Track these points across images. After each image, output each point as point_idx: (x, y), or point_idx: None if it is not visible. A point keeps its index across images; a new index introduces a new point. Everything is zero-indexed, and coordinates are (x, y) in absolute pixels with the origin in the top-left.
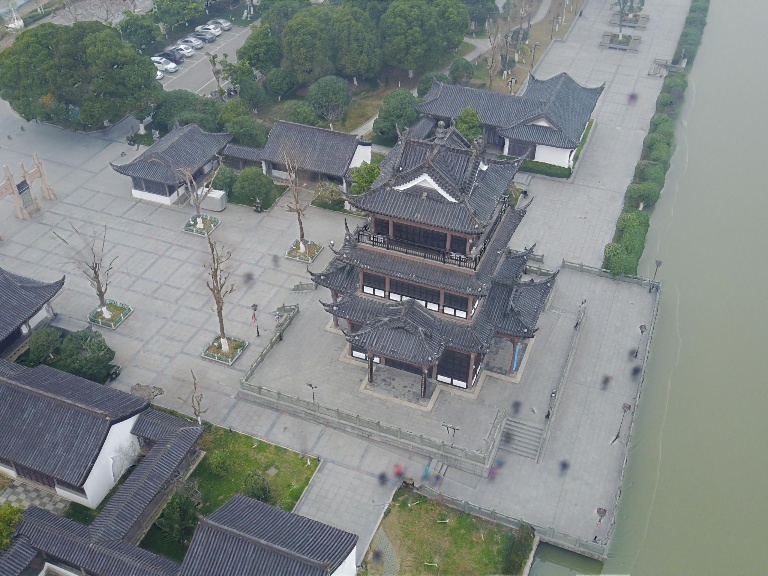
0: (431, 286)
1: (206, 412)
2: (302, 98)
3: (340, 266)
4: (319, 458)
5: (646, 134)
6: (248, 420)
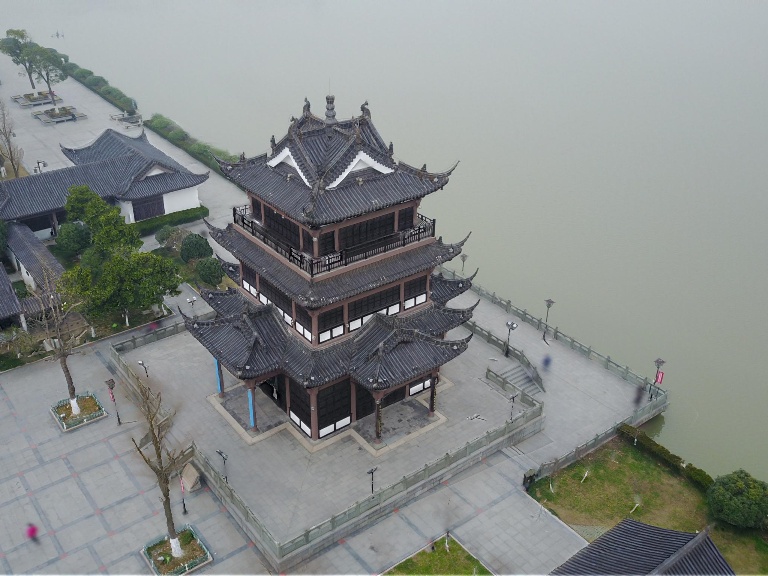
0: None
1: None
2: None
3: (252, 344)
4: (446, 534)
5: (201, 165)
6: None
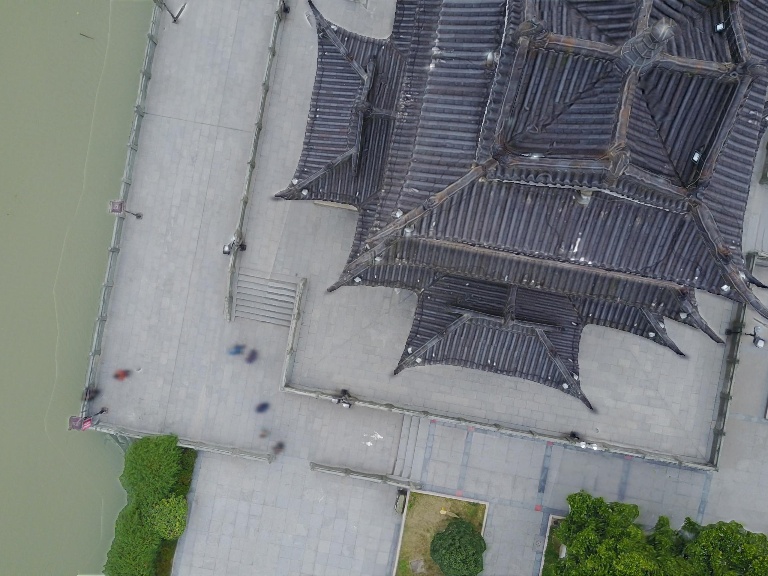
0: None
1: None
2: None
3: None
4: None
5: None
6: None
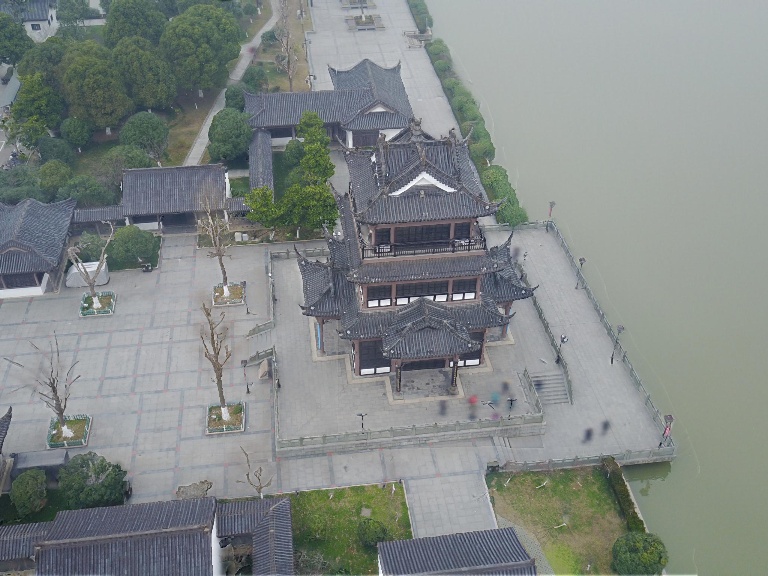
0: (446, 278)
1: None
2: (104, 144)
3: (324, 291)
4: (399, 480)
5: (445, 100)
6: (304, 476)
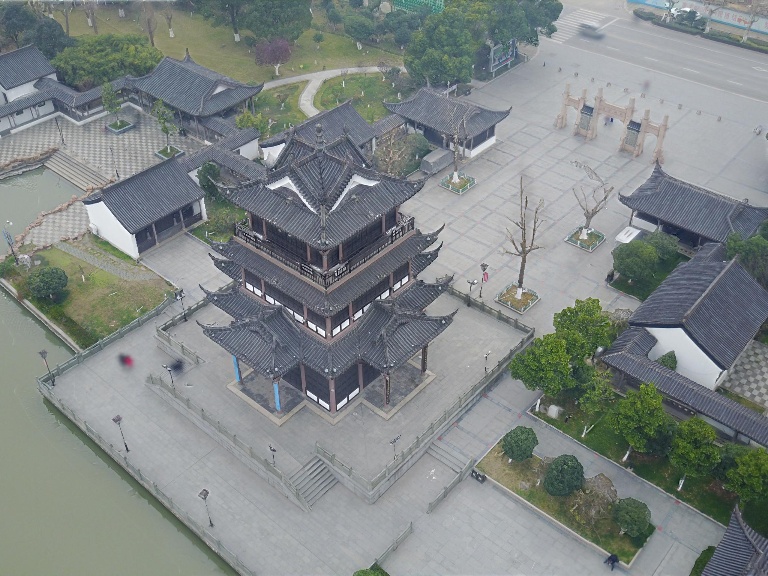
0: None
1: None
2: None
3: None
4: None
5: None
6: None
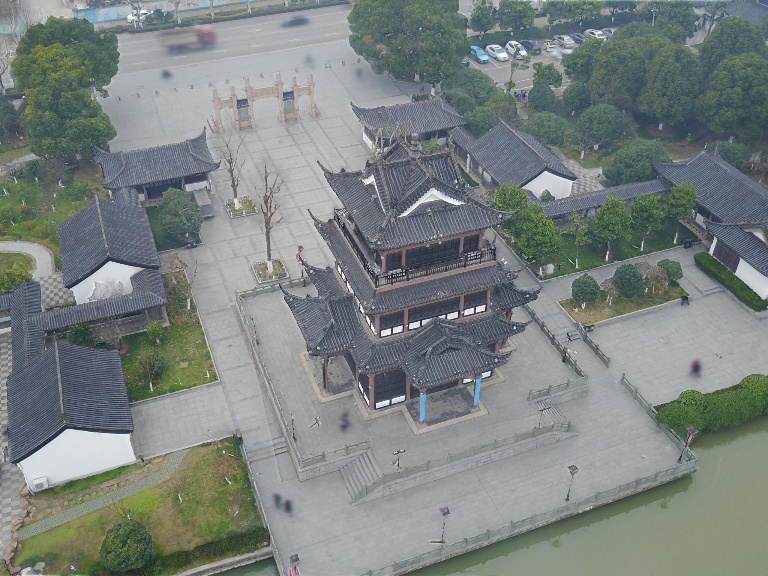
0: None
1: (205, 302)
2: None
3: None
4: (218, 378)
5: None
6: (219, 324)
